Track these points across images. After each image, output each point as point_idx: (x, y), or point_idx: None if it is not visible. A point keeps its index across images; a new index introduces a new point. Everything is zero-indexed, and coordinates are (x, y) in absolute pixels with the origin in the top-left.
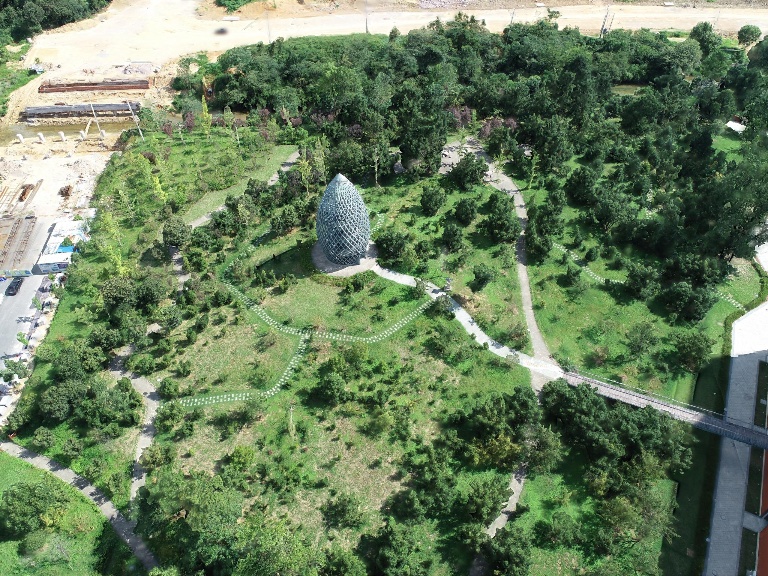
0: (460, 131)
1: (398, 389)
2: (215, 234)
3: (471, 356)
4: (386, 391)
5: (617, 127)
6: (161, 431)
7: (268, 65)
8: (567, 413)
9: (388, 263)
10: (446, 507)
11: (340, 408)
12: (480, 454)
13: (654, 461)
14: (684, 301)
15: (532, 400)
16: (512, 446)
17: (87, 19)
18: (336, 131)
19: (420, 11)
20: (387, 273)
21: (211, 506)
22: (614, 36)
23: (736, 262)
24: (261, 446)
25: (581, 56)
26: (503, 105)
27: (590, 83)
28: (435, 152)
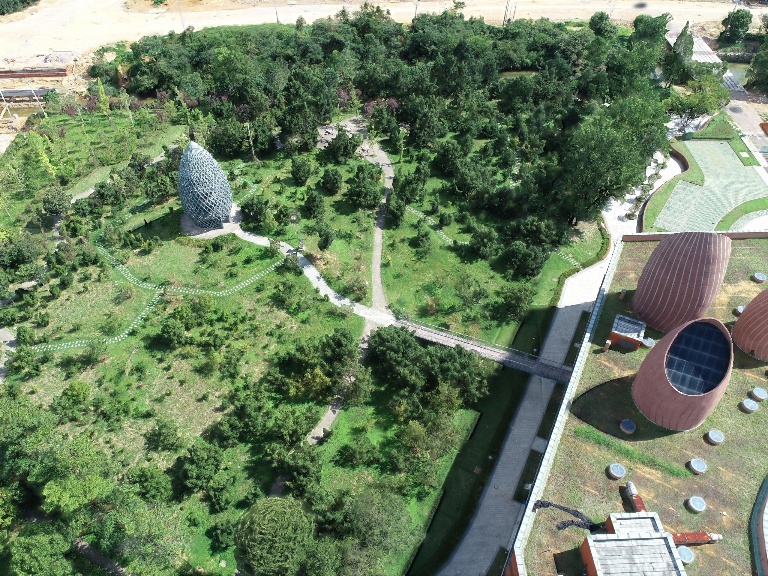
0: (335, 108)
1: (237, 335)
2: (95, 203)
3: (312, 307)
4: (225, 336)
5: (493, 106)
6: (12, 373)
7: (178, 52)
8: (383, 352)
9: (250, 227)
10: (256, 431)
11: (180, 351)
12: (297, 387)
13: (452, 391)
14: (518, 258)
15: (348, 339)
16: (322, 378)
17: (17, 12)
18: (226, 111)
19: (341, 4)
20: (248, 236)
21: (13, 418)
22: (515, 25)
23: (584, 227)
24: (100, 383)
25: (463, 41)
26: (388, 87)
27: (465, 65)
28: (309, 128)
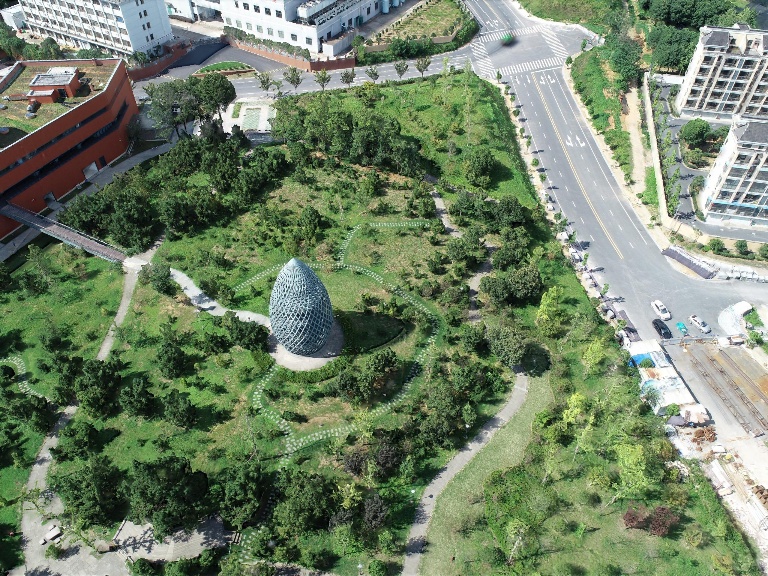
0: (77, 523)
1: None
2: None
3: None
4: (272, 230)
5: None
6: None
7: None
8: None
9: None
10: None
11: None
12: None
13: None
14: None
15: None
16: None
17: None
18: None
19: None
20: (259, 320)
21: None
22: None
23: None
24: None
25: None
26: None
27: None
28: None
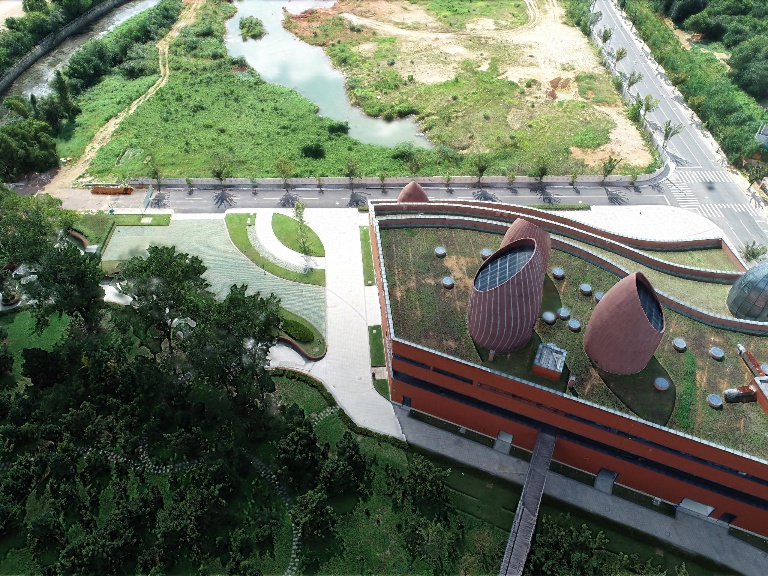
0: None
1: None
2: None
3: None
4: None
5: None
6: None
7: None
8: None
9: None
10: None
11: None
12: None
13: (607, 569)
14: None
15: None
16: None
17: None
18: None
19: None
20: None
21: None
22: None
23: None
24: None
25: None
26: None
27: None
28: None
